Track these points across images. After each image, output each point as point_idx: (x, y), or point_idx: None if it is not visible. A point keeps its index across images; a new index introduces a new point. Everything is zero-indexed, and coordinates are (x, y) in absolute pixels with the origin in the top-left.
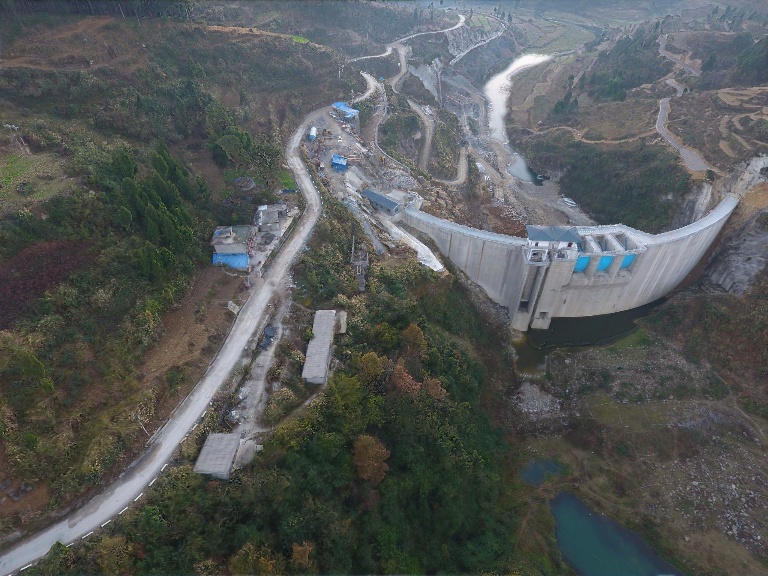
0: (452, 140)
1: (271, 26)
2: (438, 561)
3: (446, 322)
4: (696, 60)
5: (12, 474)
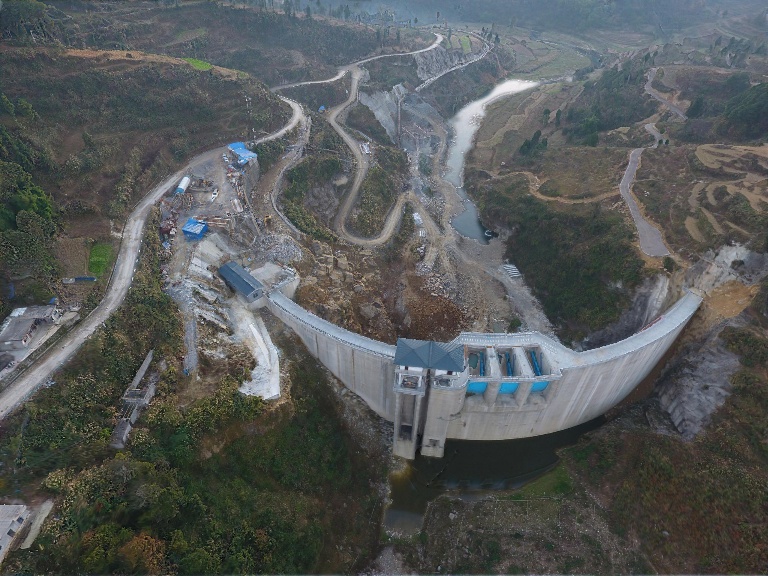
0: (387, 186)
1: (188, 46)
2: None
3: (274, 470)
4: (685, 101)
5: None
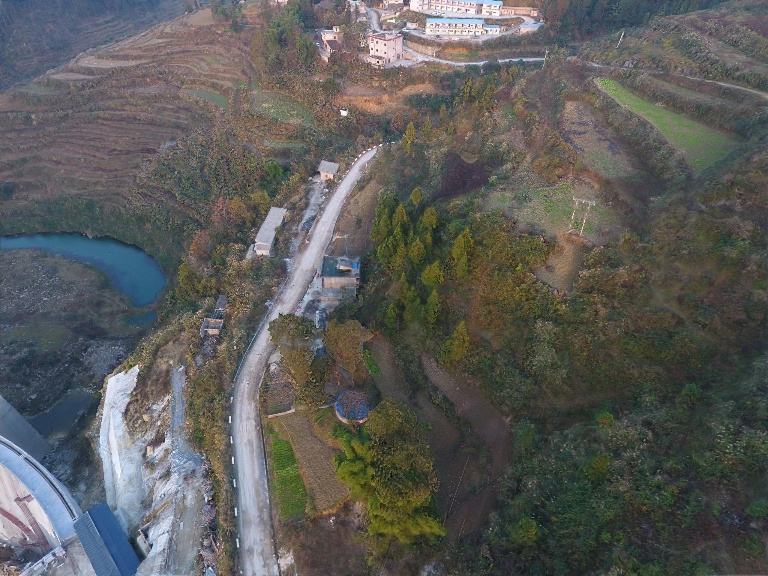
0: None
1: None
2: None
3: None
4: None
5: None
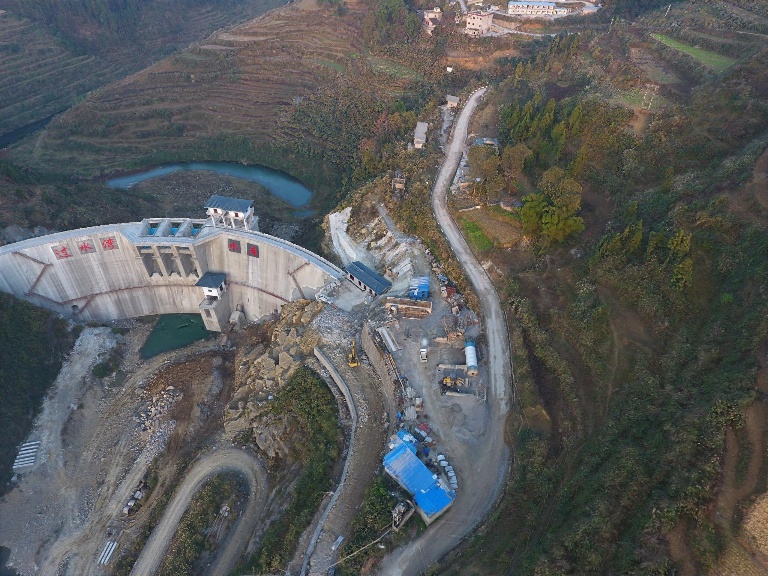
0: None
1: None
2: None
3: None
4: None
5: None
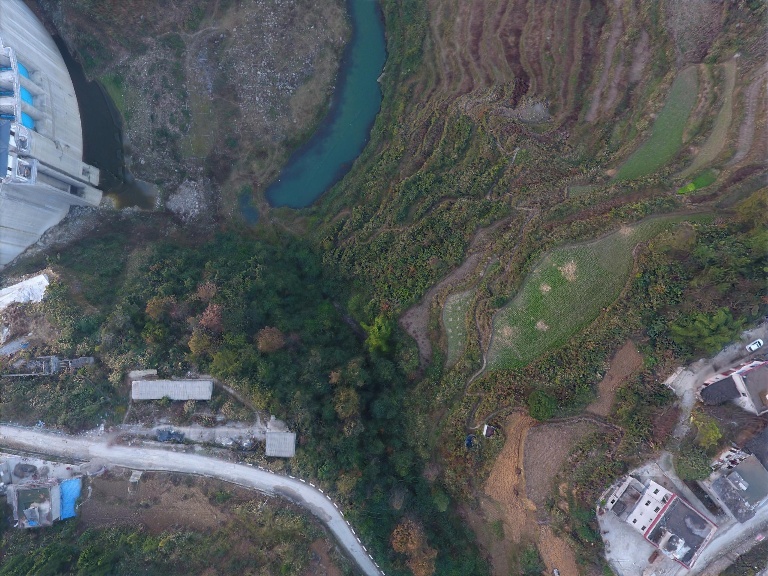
0: None
1: None
2: (317, 292)
3: (111, 275)
4: None
5: (307, 569)
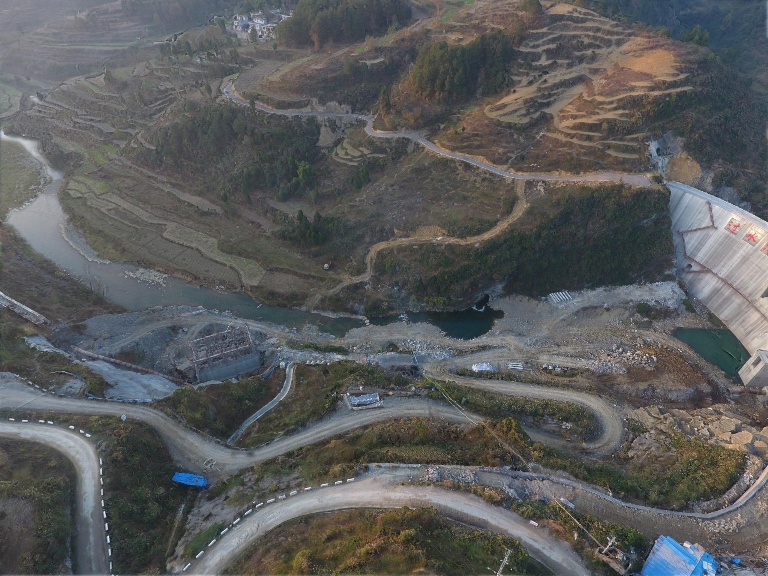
0: None
1: None
2: None
3: None
4: (329, 104)
5: None
